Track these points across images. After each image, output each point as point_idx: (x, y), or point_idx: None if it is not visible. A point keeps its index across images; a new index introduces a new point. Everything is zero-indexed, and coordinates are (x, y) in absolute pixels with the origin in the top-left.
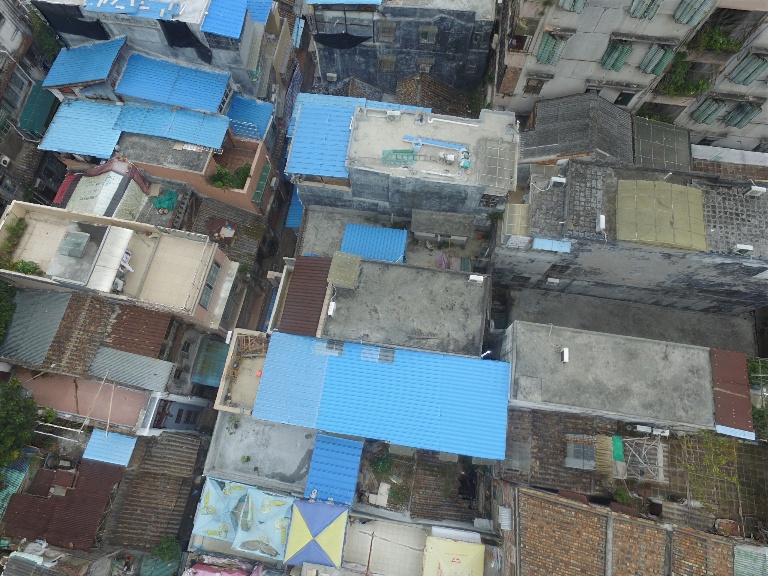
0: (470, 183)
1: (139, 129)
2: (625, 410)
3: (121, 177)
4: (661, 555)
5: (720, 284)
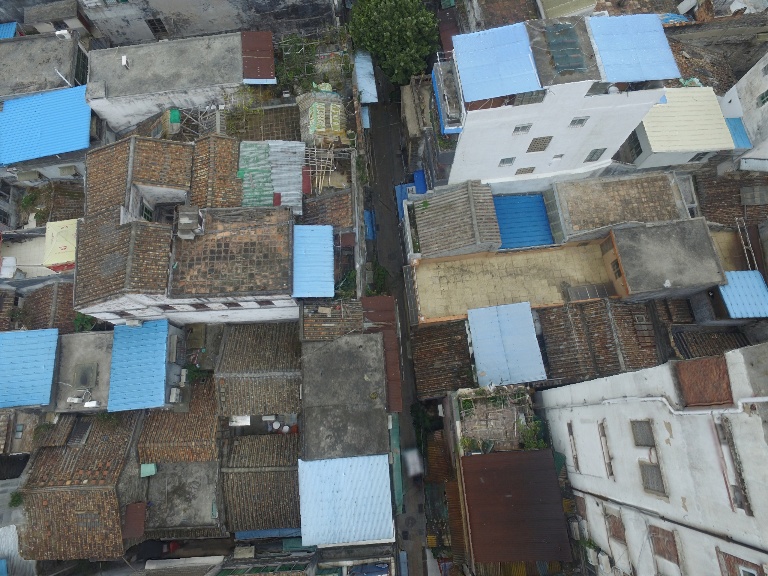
0: None
1: None
2: (176, 88)
3: None
4: (188, 161)
5: (273, 0)
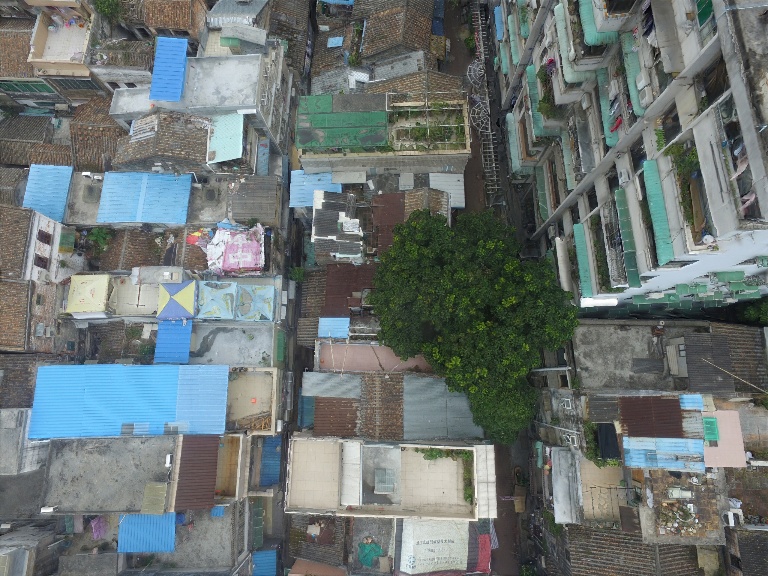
0: None
1: None
2: None
3: (402, 569)
4: None
5: None
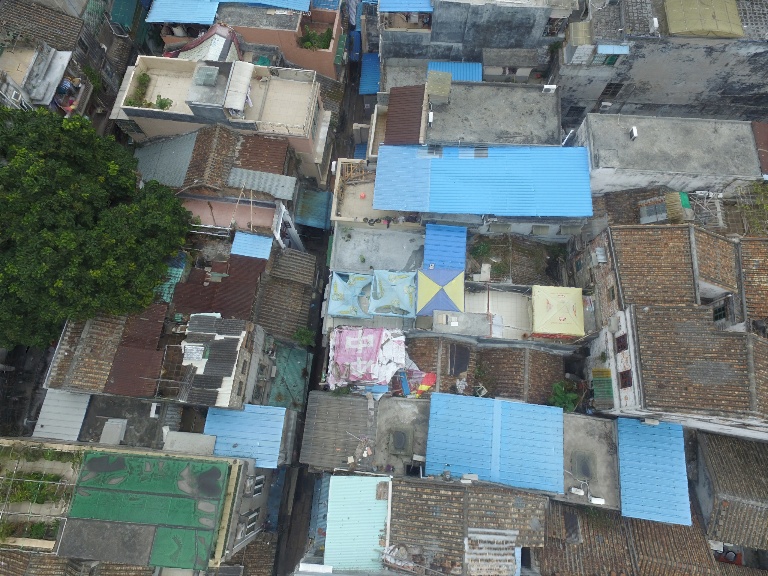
0: (539, 6)
1: None
2: (688, 170)
3: (224, 39)
4: (732, 260)
5: (751, 86)
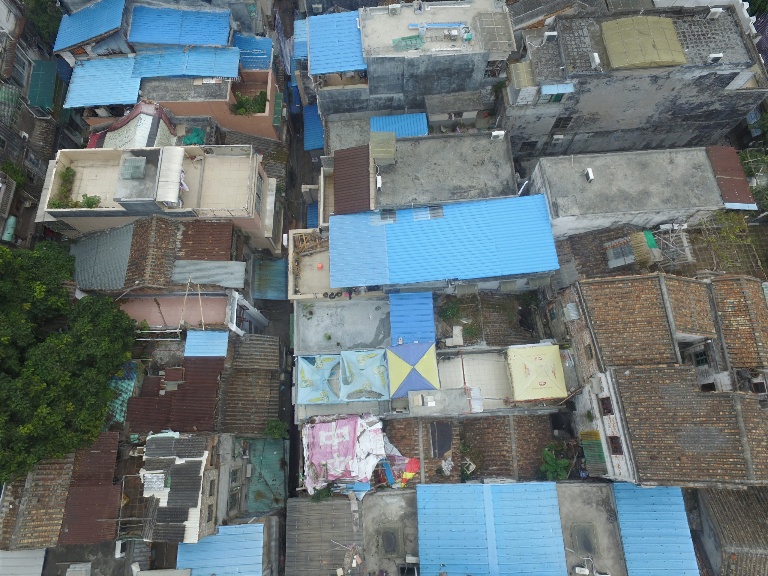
0: (476, 51)
1: (157, 73)
2: (649, 208)
3: (151, 118)
4: (707, 303)
5: (699, 105)
